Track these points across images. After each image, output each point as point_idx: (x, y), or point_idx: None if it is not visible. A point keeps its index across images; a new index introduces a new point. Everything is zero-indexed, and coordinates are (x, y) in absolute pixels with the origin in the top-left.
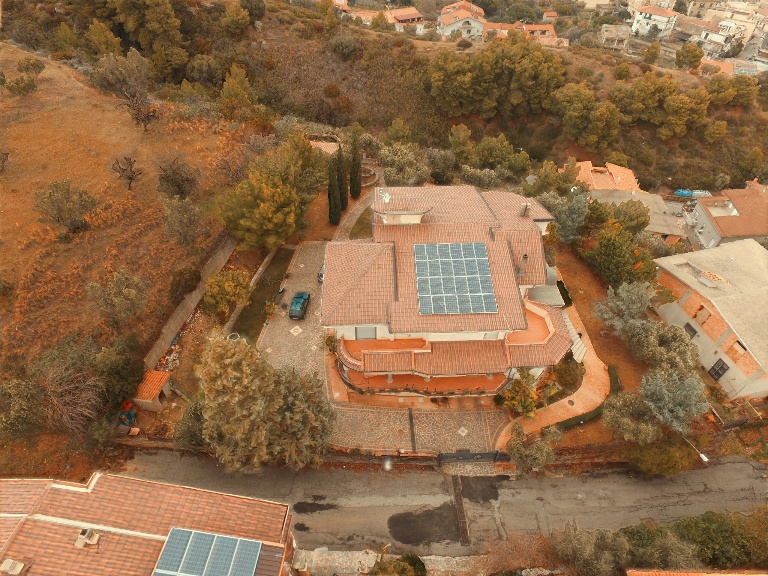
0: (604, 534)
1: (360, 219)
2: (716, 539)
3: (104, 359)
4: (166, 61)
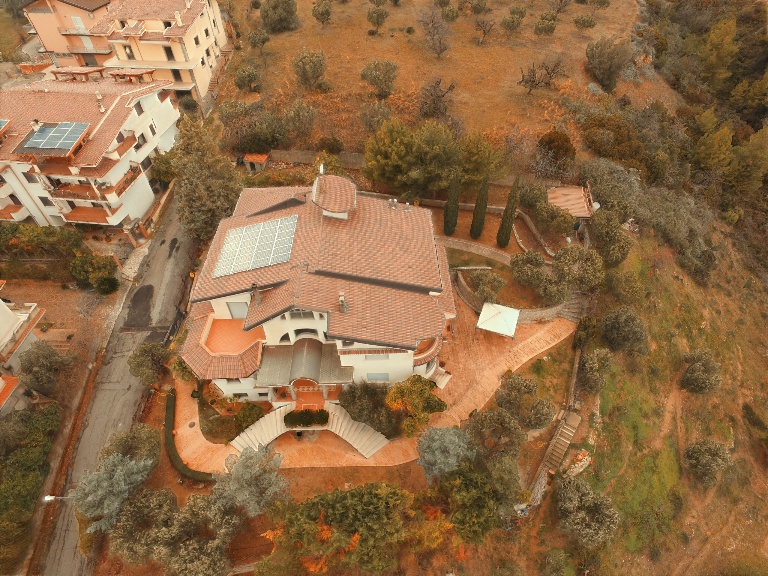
0: (41, 368)
1: (460, 251)
2: (1, 493)
3: (257, 127)
4: (763, 93)
